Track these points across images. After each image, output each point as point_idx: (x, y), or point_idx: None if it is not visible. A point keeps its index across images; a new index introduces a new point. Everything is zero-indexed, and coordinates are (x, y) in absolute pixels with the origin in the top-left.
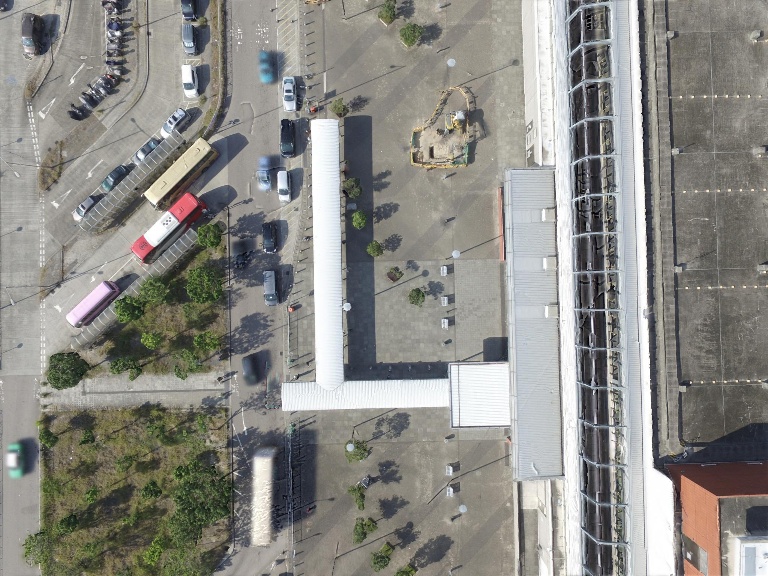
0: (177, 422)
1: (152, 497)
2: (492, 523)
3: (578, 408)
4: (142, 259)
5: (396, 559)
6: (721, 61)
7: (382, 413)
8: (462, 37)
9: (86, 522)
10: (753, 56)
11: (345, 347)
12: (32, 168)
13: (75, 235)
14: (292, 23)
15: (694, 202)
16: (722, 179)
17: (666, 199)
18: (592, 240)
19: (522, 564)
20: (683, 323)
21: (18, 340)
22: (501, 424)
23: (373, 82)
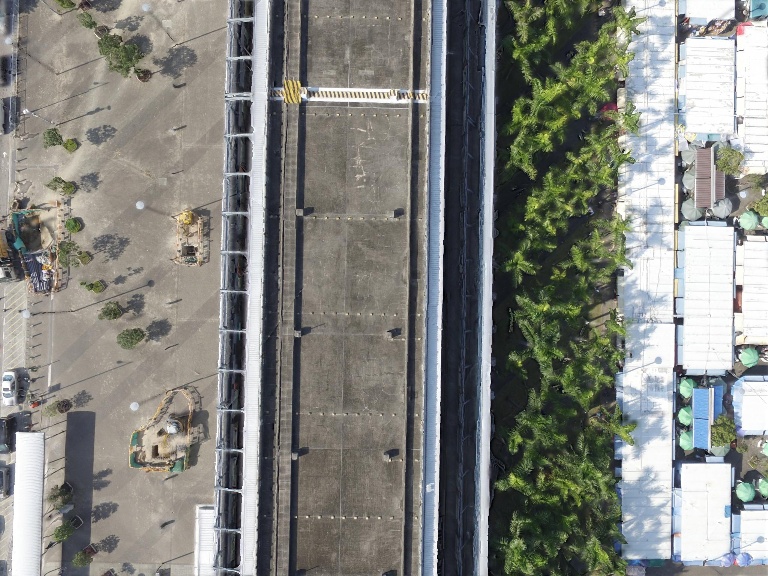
0: None
1: None
2: None
3: None
4: None
5: None
6: (352, 480)
7: None
8: (191, 334)
9: None
10: (386, 475)
11: None
12: None
13: None
14: (20, 313)
15: None
16: None
17: None
18: None
19: None
20: None
21: None
22: None
23: (98, 377)
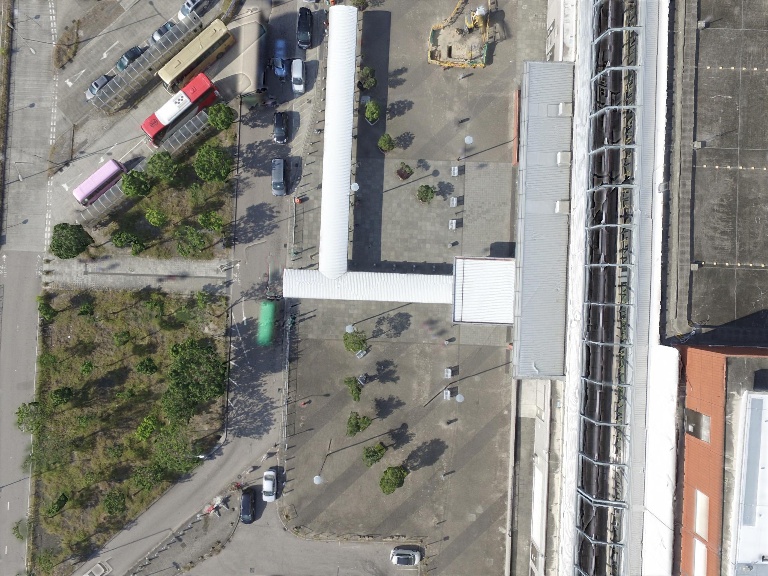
0: (177, 307)
1: (147, 372)
2: (488, 430)
3: (584, 292)
4: (152, 137)
5: (388, 460)
6: None
7: (383, 312)
8: None
9: (80, 401)
10: None
11: (350, 243)
12: (48, 45)
13: (87, 115)
14: None
15: (718, 79)
16: (748, 57)
17: (689, 72)
18: (609, 134)
19: (516, 473)
20: (699, 202)
21: (24, 216)
22: (504, 322)
23: None
